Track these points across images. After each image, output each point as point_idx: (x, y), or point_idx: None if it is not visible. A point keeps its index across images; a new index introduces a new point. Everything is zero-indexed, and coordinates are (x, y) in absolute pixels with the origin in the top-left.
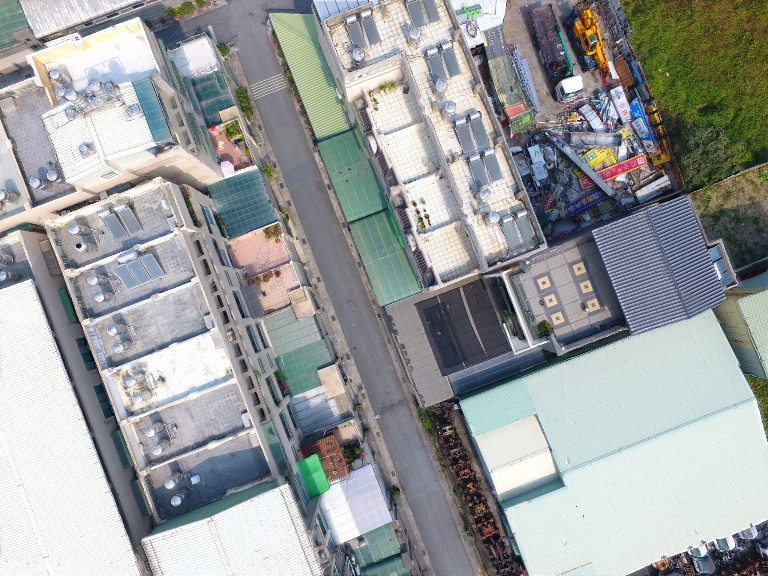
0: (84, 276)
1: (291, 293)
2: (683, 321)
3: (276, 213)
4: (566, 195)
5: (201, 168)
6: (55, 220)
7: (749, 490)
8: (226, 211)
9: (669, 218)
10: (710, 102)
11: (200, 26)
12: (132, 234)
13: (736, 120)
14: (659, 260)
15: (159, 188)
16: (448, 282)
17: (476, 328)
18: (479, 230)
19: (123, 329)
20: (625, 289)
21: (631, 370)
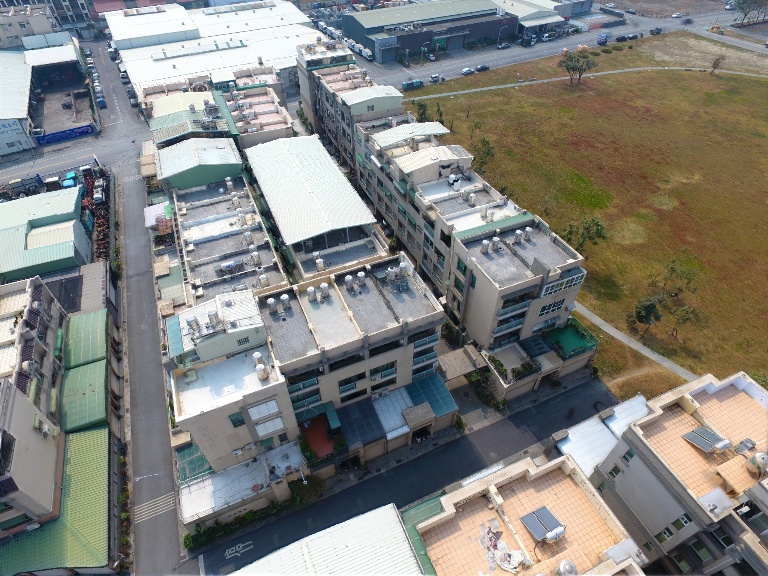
0: None
1: (171, 312)
2: None
3: None
4: None
5: None
6: (279, 284)
7: None
8: None
9: None
10: None
11: None
12: None
13: None
14: None
15: None
16: (23, 281)
17: None
18: None
19: None
20: None
21: None
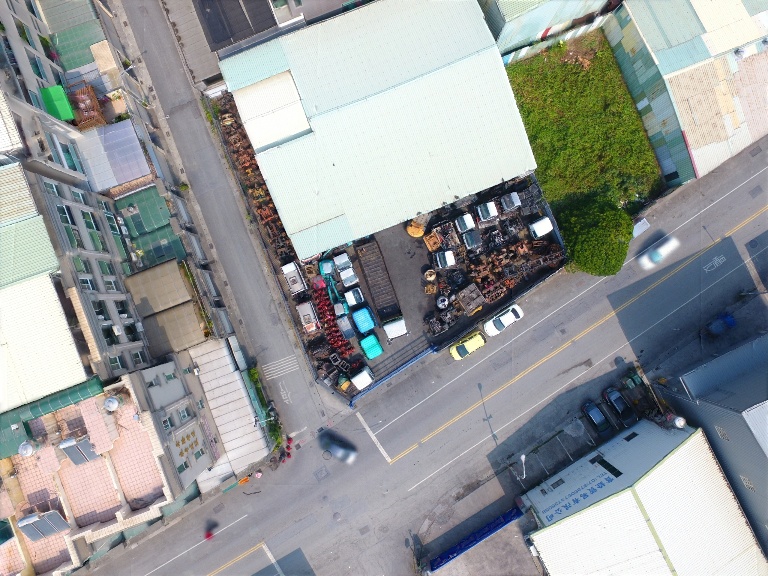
0: None
1: None
2: None
3: None
4: None
5: None
6: None
7: (498, 143)
8: None
9: None
10: None
11: None
12: None
13: None
14: None
15: None
16: None
17: (244, 5)
18: None
19: None
20: None
21: (383, 28)
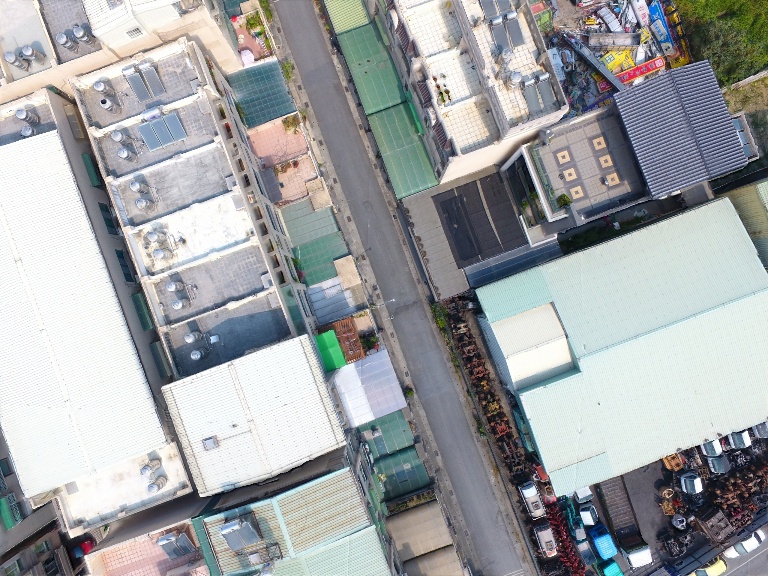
0: (107, 138)
1: (309, 184)
2: (701, 212)
3: (295, 104)
4: (583, 99)
5: (223, 46)
6: (80, 78)
7: (766, 382)
8: (245, 101)
9: (691, 80)
10: (729, 9)
11: None
12: (155, 97)
13: (755, 25)
14: (681, 121)
15: (183, 52)
16: (468, 153)
17: (493, 221)
18: (500, 95)
19: (145, 188)
20: (646, 152)
21: (648, 260)
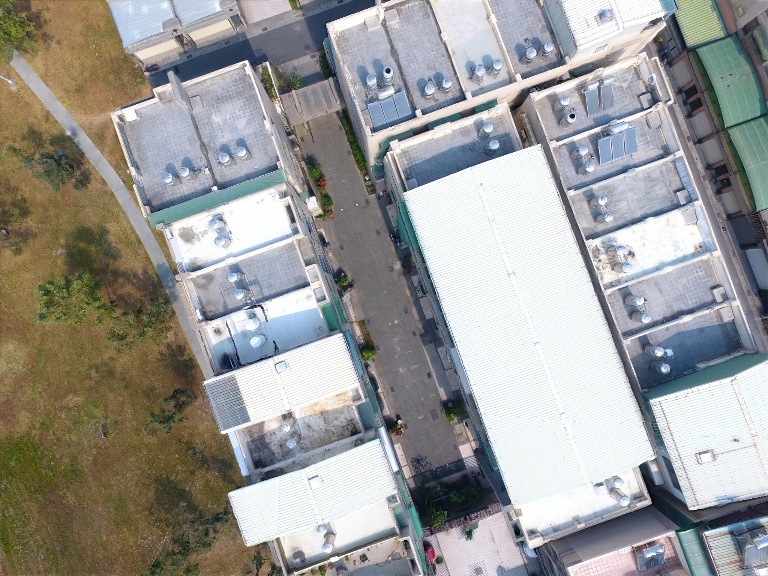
0: (555, 152)
1: None
2: None
3: None
4: None
5: None
6: (540, 93)
7: None
8: None
9: None
10: None
11: None
12: (603, 111)
13: None
14: None
15: (630, 67)
16: None
17: None
18: None
19: None
20: None
21: None
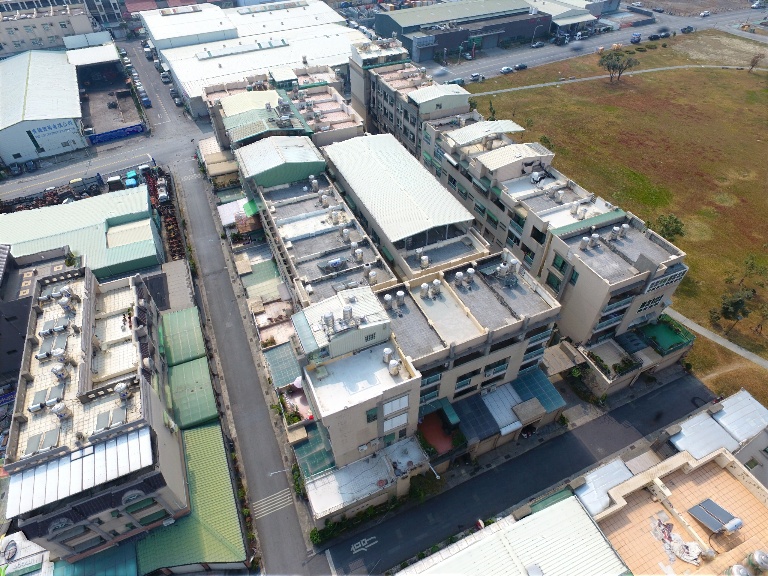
0: None
1: (262, 309)
2: None
3: (265, 358)
4: (8, 410)
5: None
6: (389, 281)
7: None
8: None
9: None
10: None
11: (347, 575)
12: None
13: None
14: None
15: None
16: (124, 279)
17: None
18: (83, 293)
19: None
20: None
21: None
